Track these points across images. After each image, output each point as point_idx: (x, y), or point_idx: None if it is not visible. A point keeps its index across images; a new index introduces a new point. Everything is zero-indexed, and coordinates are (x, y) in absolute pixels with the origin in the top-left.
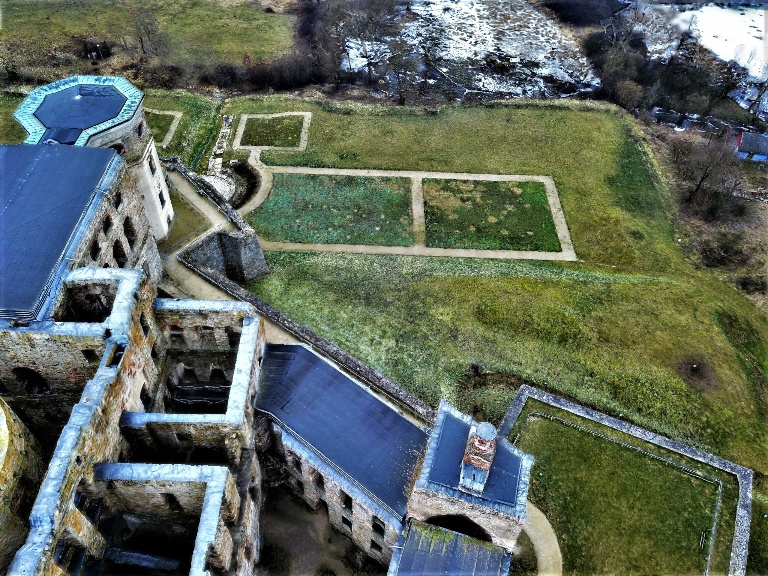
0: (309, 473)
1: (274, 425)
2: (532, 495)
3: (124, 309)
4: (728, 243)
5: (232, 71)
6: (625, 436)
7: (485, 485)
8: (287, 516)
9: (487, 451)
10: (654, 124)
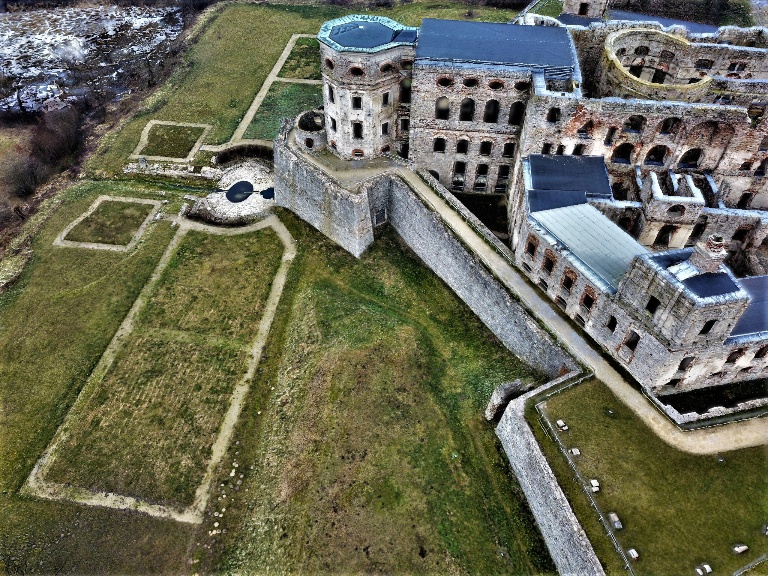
0: None
1: None
2: None
3: None
4: None
5: (19, 172)
6: None
7: None
8: None
9: None
10: None
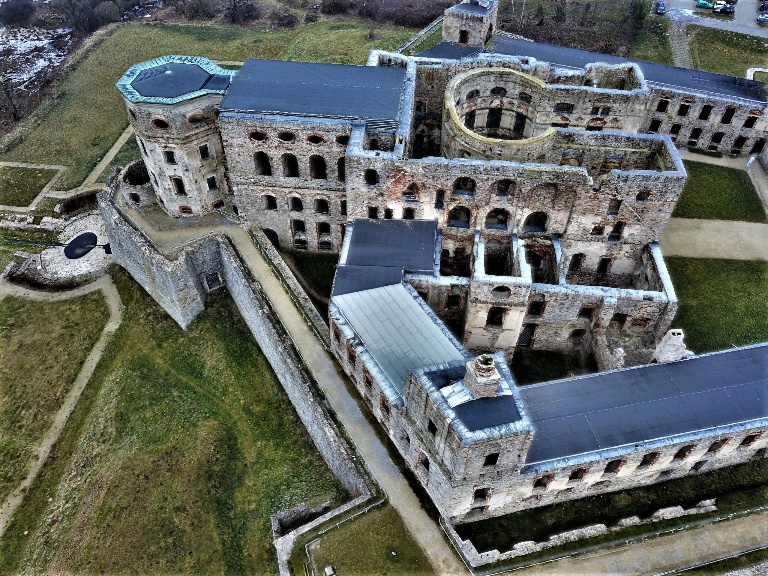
0: None
1: None
2: None
3: None
4: (277, 17)
5: None
6: None
7: None
8: None
9: None
10: None
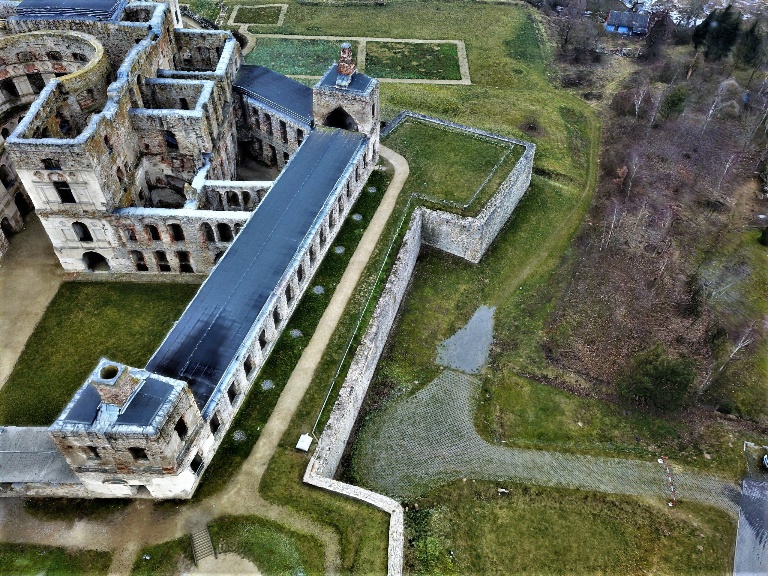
0: (264, 122)
1: (244, 96)
2: (398, 150)
3: (159, 16)
4: (583, 75)
5: None
6: (462, 131)
7: (349, 84)
8: (253, 169)
9: (347, 58)
10: (554, 16)
